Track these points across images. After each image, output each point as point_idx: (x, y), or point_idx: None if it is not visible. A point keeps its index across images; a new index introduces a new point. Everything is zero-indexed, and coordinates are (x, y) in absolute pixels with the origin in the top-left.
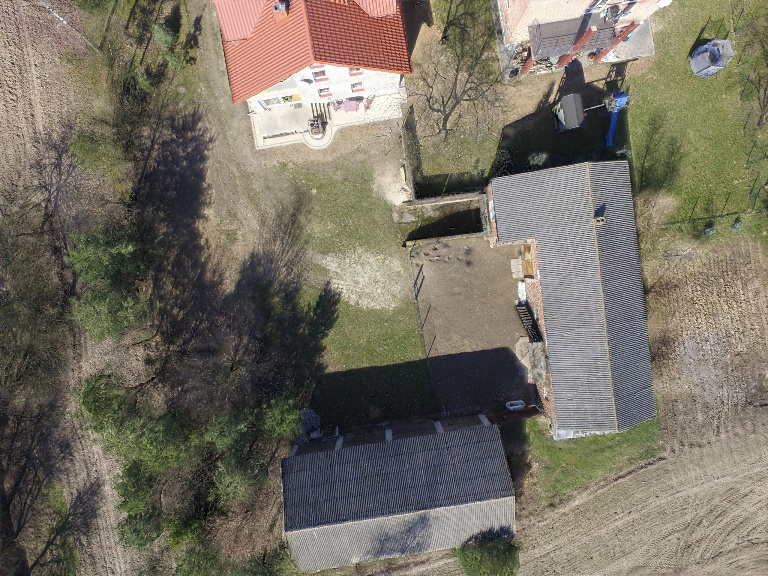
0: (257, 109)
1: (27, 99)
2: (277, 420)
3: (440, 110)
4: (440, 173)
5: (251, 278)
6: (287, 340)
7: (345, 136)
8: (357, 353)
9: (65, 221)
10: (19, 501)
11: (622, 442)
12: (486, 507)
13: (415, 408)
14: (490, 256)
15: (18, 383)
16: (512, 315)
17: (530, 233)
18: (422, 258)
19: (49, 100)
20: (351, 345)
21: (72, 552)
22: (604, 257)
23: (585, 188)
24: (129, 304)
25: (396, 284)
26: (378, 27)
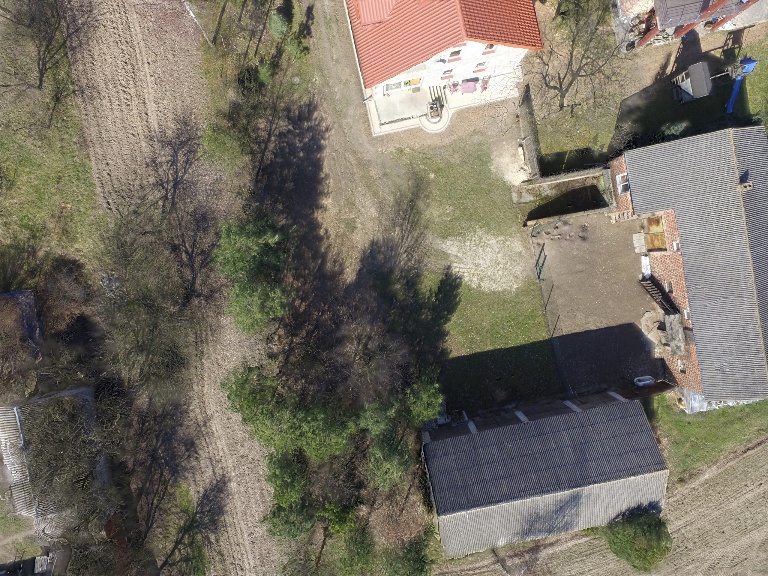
0: (377, 95)
1: (141, 98)
2: (423, 404)
3: (557, 87)
4: (559, 151)
5: (372, 266)
6: (410, 327)
7: (462, 118)
8: (481, 336)
9: (183, 218)
10: (146, 502)
11: (751, 413)
12: (639, 482)
13: (541, 389)
14: (611, 232)
15: (141, 383)
16: (636, 290)
17: (669, 204)
18: (543, 237)
19: (163, 98)
20: (474, 329)
21: (201, 550)
22: (750, 223)
23: (728, 155)
24: (275, 294)
25: (517, 265)
26: (513, 3)
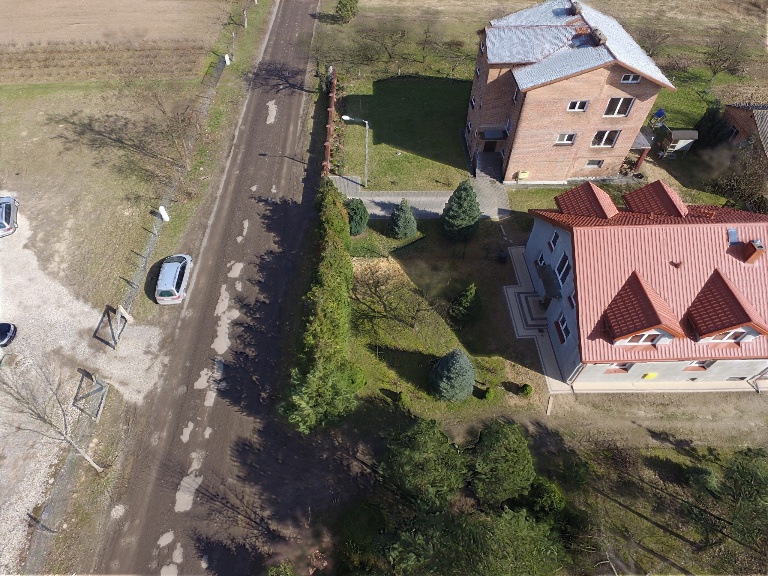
0: None
1: None
2: None
3: None
4: None
5: None
6: None
7: None
8: None
9: None
10: None
11: None
12: None
13: None
14: None
15: None
16: None
17: None
18: None
19: None
20: None
21: None
22: None
23: None
24: None
25: None
26: None
